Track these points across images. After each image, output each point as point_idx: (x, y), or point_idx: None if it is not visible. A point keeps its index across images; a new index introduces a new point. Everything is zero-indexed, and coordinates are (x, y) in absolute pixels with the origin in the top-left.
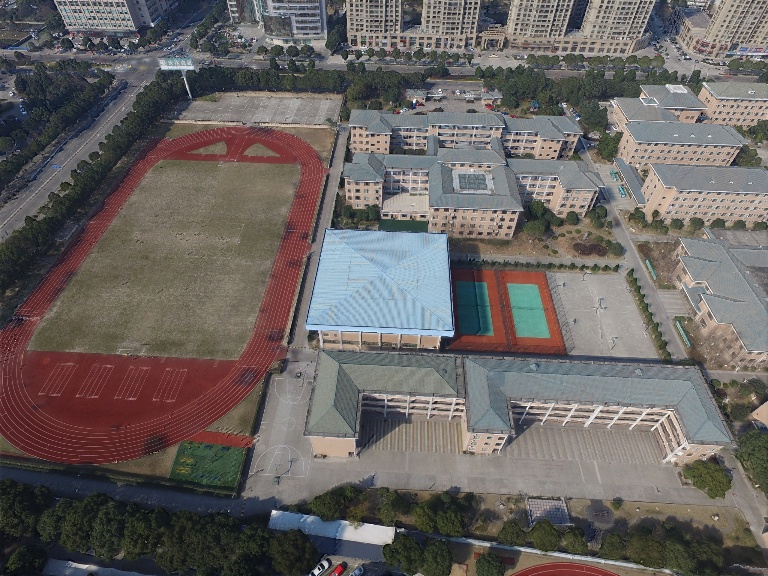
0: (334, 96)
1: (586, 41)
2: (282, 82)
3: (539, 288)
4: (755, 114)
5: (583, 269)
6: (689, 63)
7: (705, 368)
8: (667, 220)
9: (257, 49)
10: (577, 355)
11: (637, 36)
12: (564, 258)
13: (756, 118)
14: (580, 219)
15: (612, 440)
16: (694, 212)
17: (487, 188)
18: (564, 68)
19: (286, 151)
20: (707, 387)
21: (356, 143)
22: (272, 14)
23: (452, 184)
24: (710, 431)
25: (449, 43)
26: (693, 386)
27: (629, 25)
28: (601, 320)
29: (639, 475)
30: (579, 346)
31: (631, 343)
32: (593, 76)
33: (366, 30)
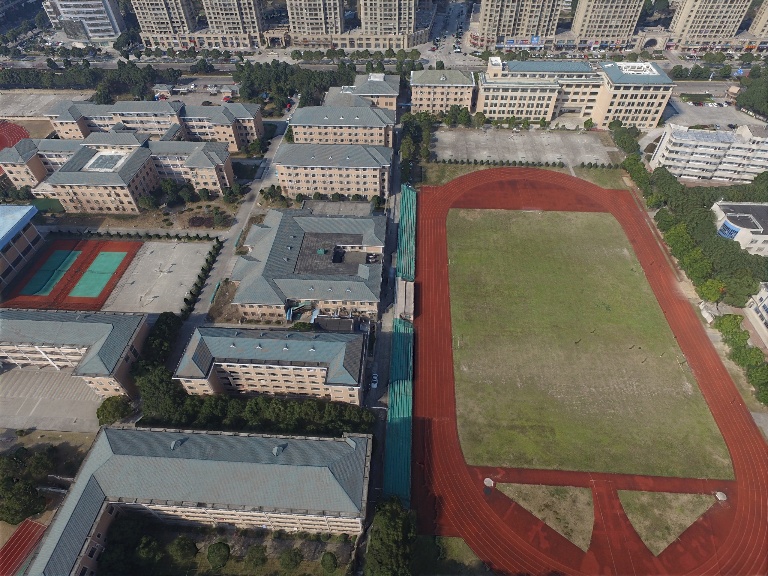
0: (91, 92)
1: (361, 37)
2: (41, 80)
3: (126, 255)
4: (454, 100)
5: (181, 239)
6: (457, 56)
7: (214, 321)
8: (296, 195)
9: (45, 51)
10: (108, 311)
11: (409, 31)
12: (173, 230)
13: (457, 103)
14: (220, 196)
15: (73, 381)
16: (314, 187)
17: (113, 167)
18: (332, 63)
19: (3, 141)
20: (137, 330)
21: (61, 132)
22: (65, 18)
23: (84, 164)
24: (95, 365)
25: (234, 42)
26: (112, 328)
27: (396, 21)
28: (157, 282)
29: (70, 409)
30: (116, 304)
31: (166, 301)
32: (343, 69)
33: (157, 32)
